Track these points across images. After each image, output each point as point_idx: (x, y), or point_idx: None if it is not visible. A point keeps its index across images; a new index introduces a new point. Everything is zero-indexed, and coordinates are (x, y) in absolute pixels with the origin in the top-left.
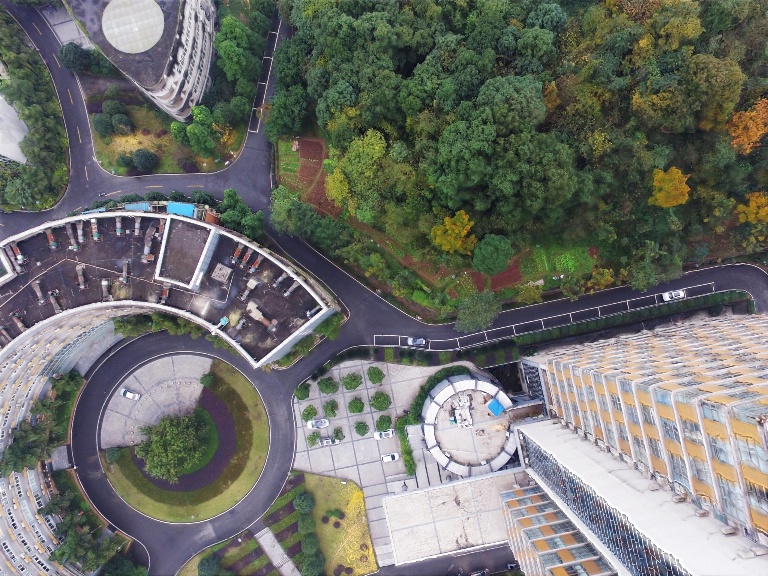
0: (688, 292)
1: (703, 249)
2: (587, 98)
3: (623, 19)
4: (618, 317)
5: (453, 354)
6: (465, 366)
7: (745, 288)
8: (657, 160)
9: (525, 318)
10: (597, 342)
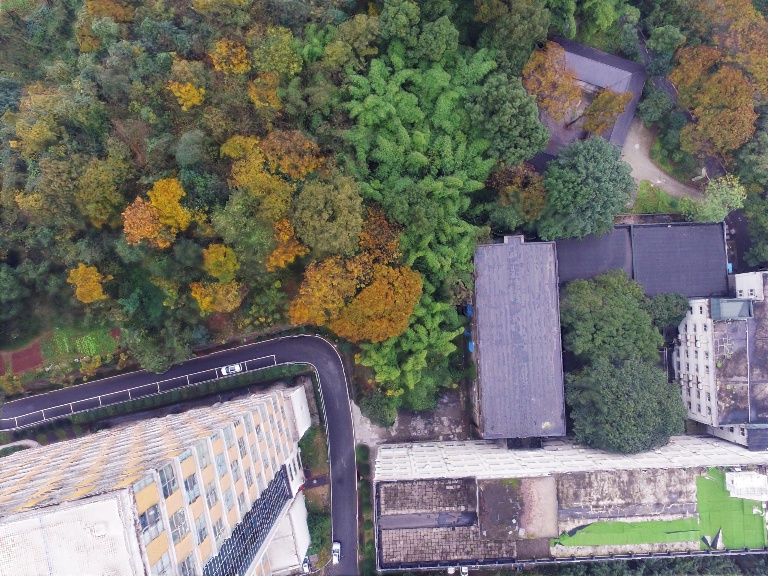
0: (248, 365)
1: (199, 332)
2: (3, 193)
3: (4, 118)
4: (174, 393)
5: (10, 434)
6: (27, 445)
7: (308, 360)
8: (81, 254)
9: (82, 396)
10: (164, 417)
